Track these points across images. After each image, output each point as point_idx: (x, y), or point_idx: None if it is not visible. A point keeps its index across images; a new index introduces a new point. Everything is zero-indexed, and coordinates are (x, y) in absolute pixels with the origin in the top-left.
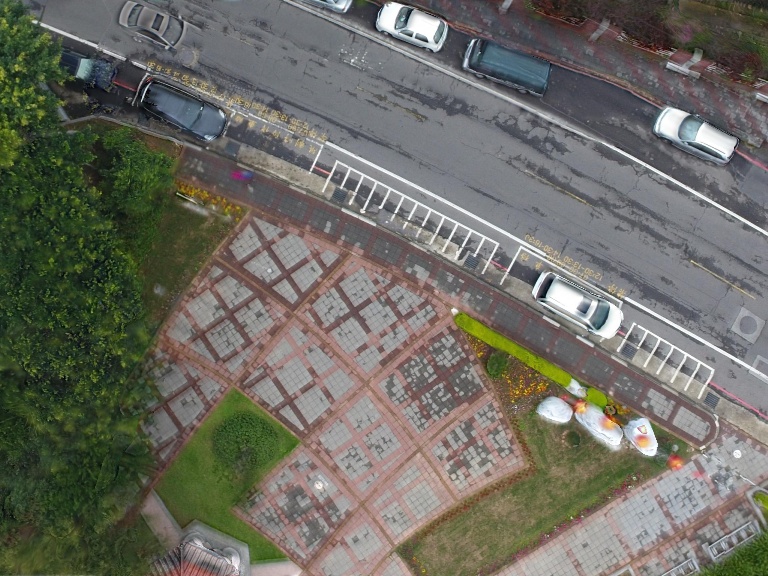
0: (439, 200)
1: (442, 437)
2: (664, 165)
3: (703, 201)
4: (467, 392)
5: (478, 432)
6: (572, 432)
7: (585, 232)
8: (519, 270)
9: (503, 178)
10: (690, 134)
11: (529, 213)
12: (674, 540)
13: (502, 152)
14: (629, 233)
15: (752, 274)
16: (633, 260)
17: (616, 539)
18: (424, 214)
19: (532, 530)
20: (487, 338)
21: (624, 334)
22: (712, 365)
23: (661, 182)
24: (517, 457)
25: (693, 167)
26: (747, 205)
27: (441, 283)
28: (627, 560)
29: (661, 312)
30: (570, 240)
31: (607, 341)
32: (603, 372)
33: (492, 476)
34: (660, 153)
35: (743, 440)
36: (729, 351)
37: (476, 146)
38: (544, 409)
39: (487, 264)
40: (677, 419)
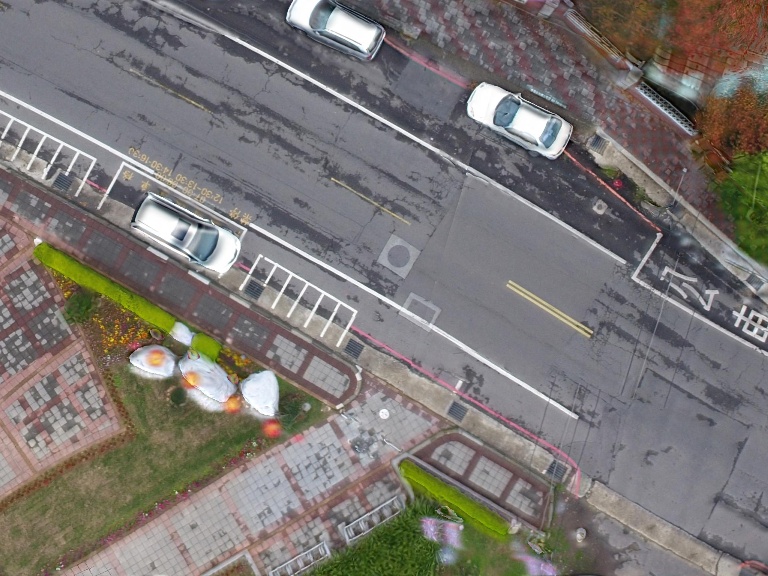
0: (23, 107)
1: (18, 395)
2: (300, 62)
3: (347, 105)
4: (50, 340)
5: (63, 389)
6: (178, 388)
7: (202, 144)
8: (120, 191)
9: (101, 79)
10: (321, 21)
11: (133, 122)
12: (303, 519)
13: (101, 47)
14: (255, 145)
15: (406, 194)
16: (260, 178)
17: (232, 518)
18: (4, 124)
19: (127, 508)
20: (69, 273)
21: (247, 268)
22: (354, 305)
23: (296, 82)
24: (110, 419)
25: (335, 64)
26: (401, 110)
27: (22, 207)
28: (245, 544)
29: (293, 241)
30: (183, 154)
31: (226, 277)
32: (219, 315)
33: (79, 442)
34: (296, 47)
35: (391, 397)
36: (375, 288)
37: (69, 40)
38: (133, 358)
39: (81, 184)
40: (308, 371)
